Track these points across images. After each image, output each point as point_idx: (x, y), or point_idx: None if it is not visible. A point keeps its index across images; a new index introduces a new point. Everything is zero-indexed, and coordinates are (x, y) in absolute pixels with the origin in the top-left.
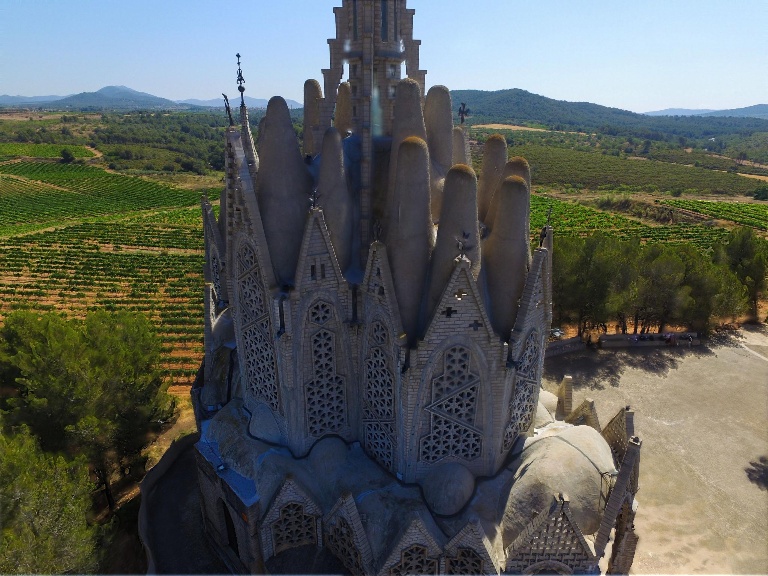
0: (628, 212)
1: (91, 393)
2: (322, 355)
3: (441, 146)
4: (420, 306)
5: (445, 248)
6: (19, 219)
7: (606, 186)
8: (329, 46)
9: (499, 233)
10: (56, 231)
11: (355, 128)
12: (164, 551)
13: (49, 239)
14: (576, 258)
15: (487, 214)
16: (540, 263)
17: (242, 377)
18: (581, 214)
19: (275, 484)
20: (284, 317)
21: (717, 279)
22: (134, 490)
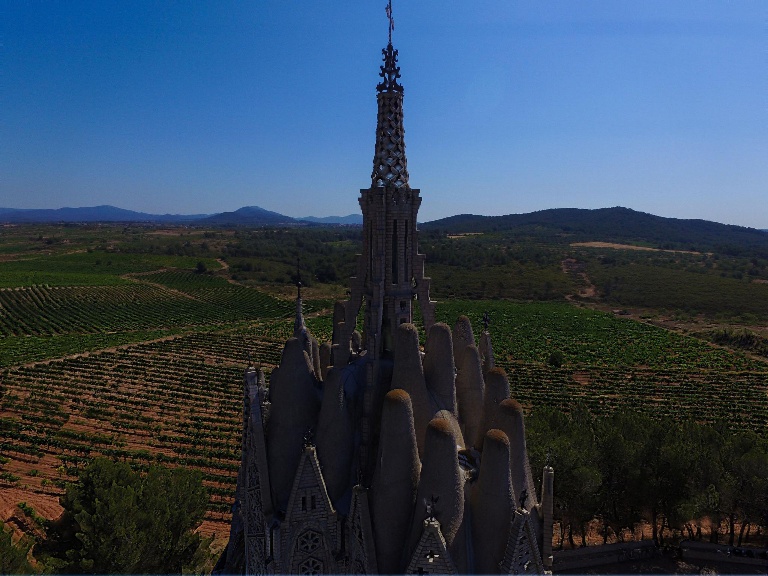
0: (751, 350)
1: (130, 559)
2: None
3: (441, 378)
4: (402, 551)
5: (423, 500)
6: (151, 324)
7: (726, 314)
8: None
9: (482, 485)
10: (175, 340)
11: None
12: None
13: (167, 348)
14: (640, 447)
15: None
16: (520, 527)
17: None
18: (692, 349)
19: None
20: (273, 545)
21: None
22: None
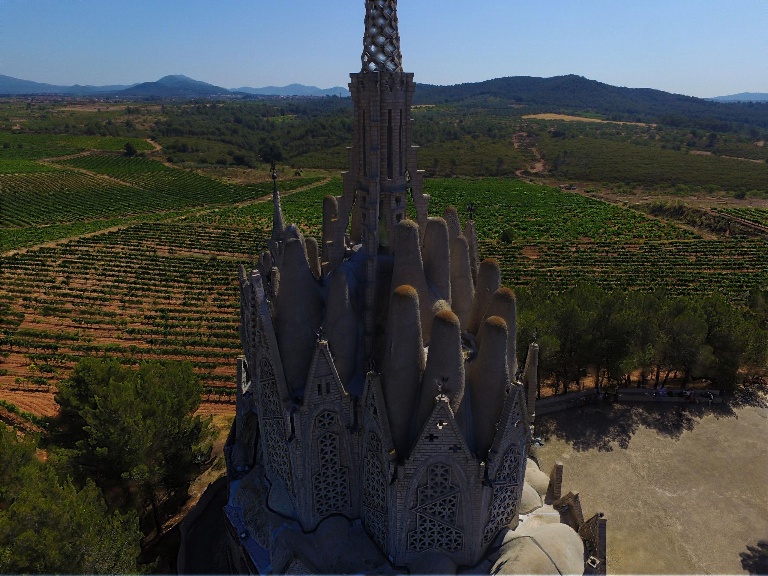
0: (681, 219)
1: (142, 444)
2: (328, 452)
3: (438, 271)
4: (411, 421)
5: (431, 380)
6: (87, 215)
7: (662, 186)
8: (343, 178)
9: (481, 364)
10: (119, 231)
11: (364, 247)
12: None
13: (113, 240)
14: (593, 316)
15: (477, 334)
16: (515, 396)
17: (264, 453)
18: (630, 220)
19: (285, 559)
20: (294, 426)
21: (744, 337)
22: (178, 515)
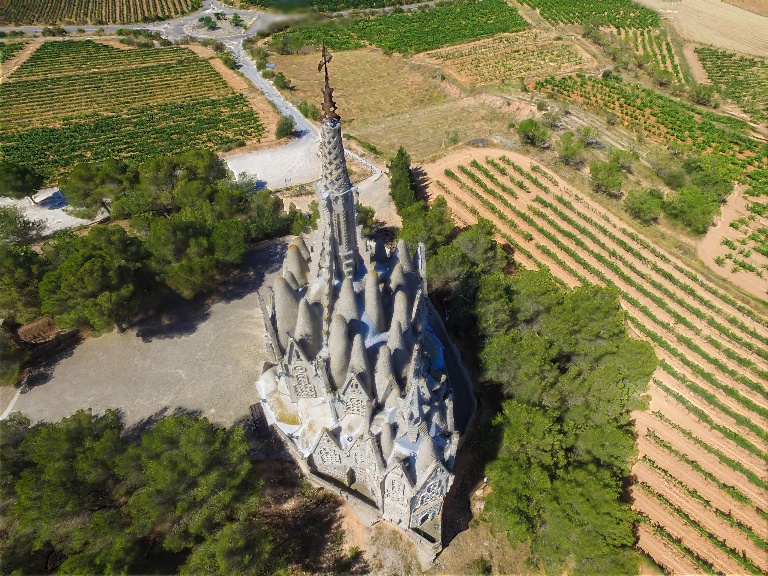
0: None
1: None
2: None
3: None
4: None
5: None
6: None
7: None
8: None
9: None
10: None
11: None
12: (458, 374)
13: None
14: None
15: None
16: None
17: None
18: None
19: None
20: None
21: None
22: None
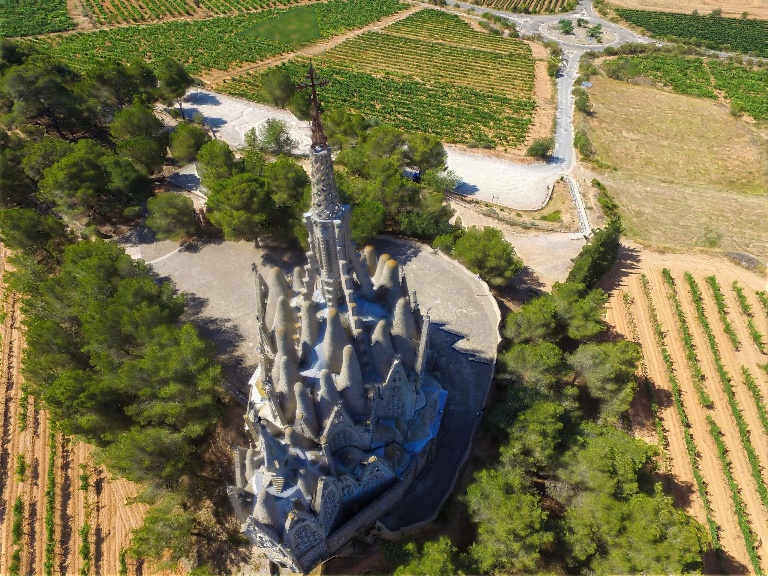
0: None
1: None
2: None
3: None
4: None
5: None
6: None
7: None
8: None
9: None
10: None
11: None
12: (450, 474)
13: None
14: None
15: None
16: None
17: None
18: None
19: None
20: None
21: None
22: None
